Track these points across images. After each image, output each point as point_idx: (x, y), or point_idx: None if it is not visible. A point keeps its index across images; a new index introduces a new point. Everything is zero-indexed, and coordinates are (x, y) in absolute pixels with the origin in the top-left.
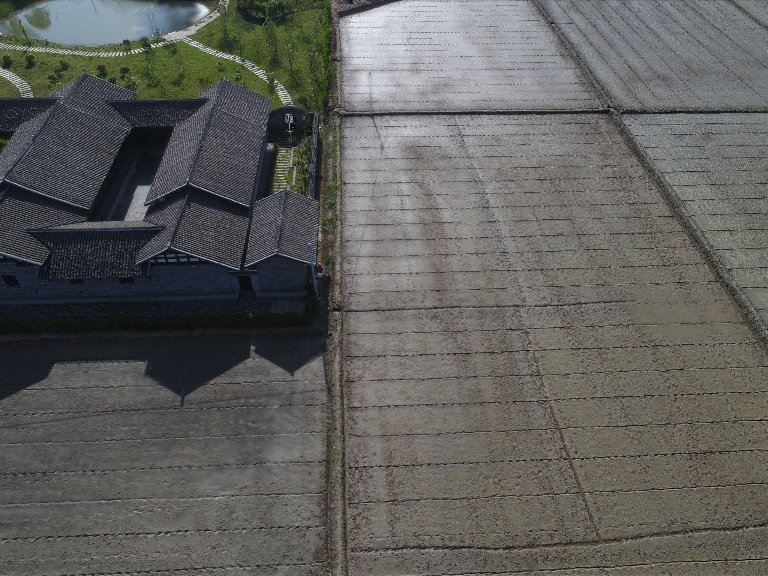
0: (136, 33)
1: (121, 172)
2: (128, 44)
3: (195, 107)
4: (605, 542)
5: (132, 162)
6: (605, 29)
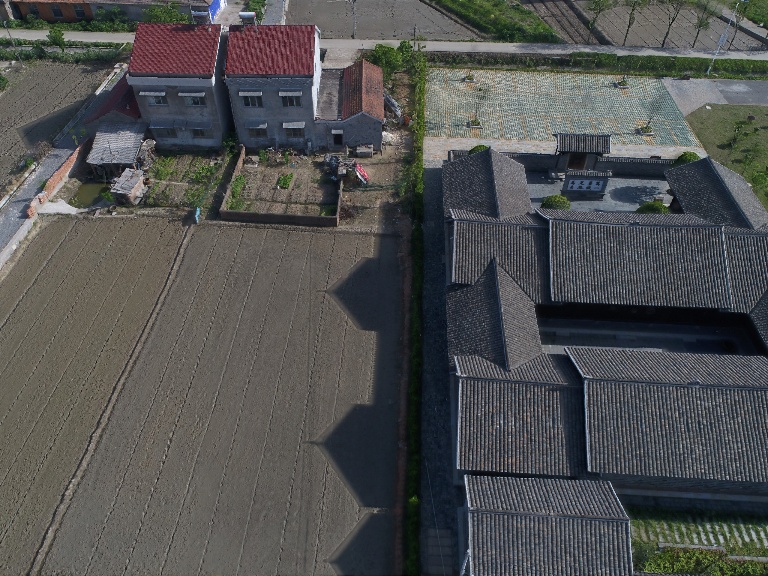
0: None
1: (680, 327)
2: None
3: None
4: None
5: (707, 334)
6: None
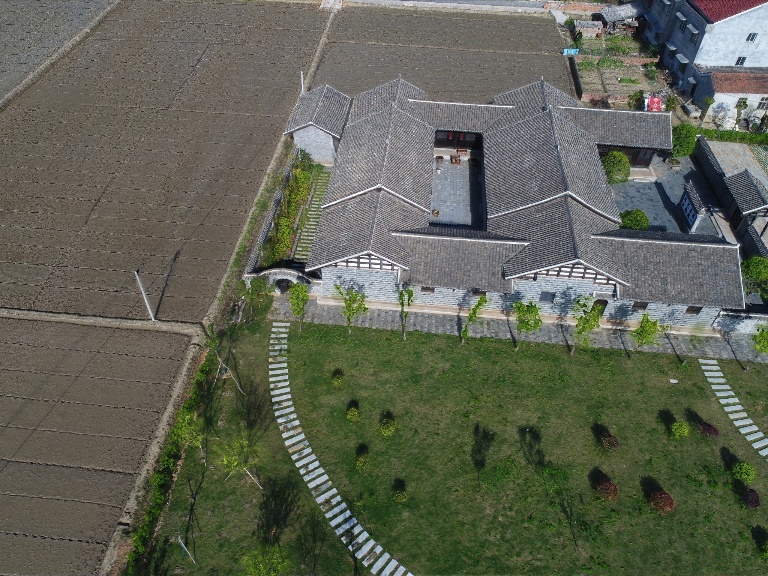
0: None
1: None
2: None
3: (409, 231)
4: None
5: None
6: None
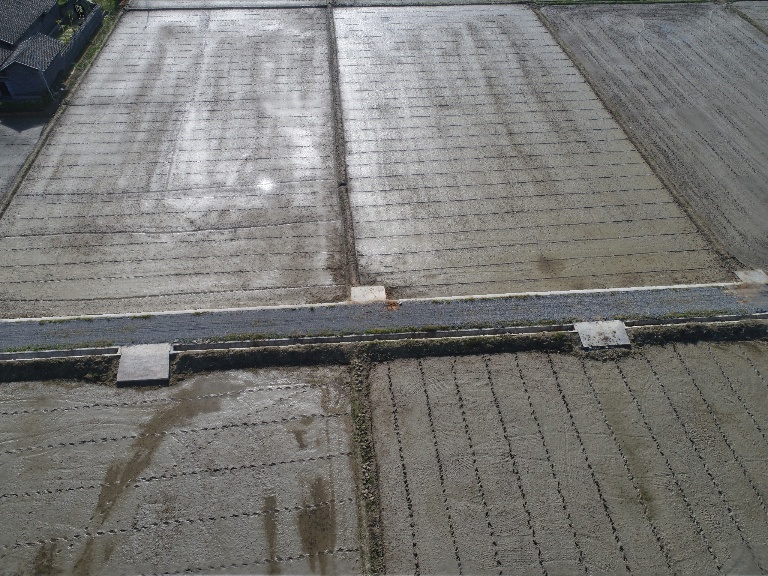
0: None
1: None
2: None
3: None
4: (168, 191)
5: None
6: None
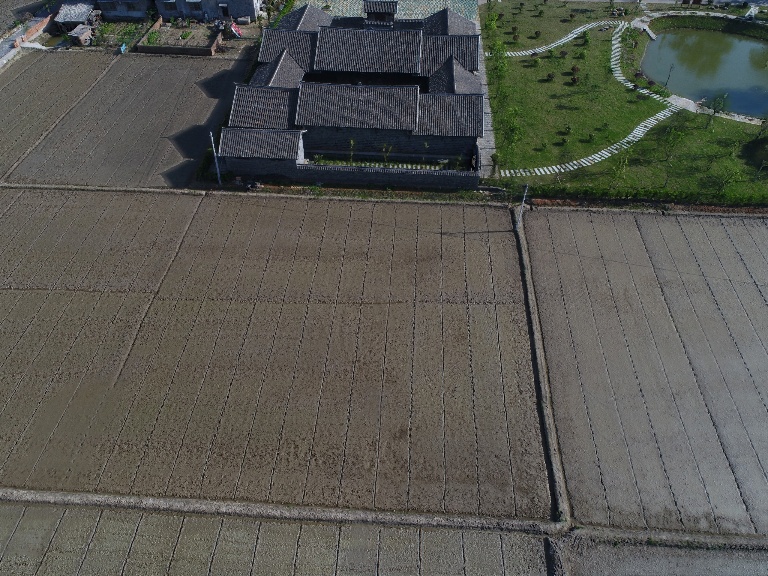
0: (700, 89)
1: None
2: (636, 77)
3: (447, 92)
4: None
5: None
6: None
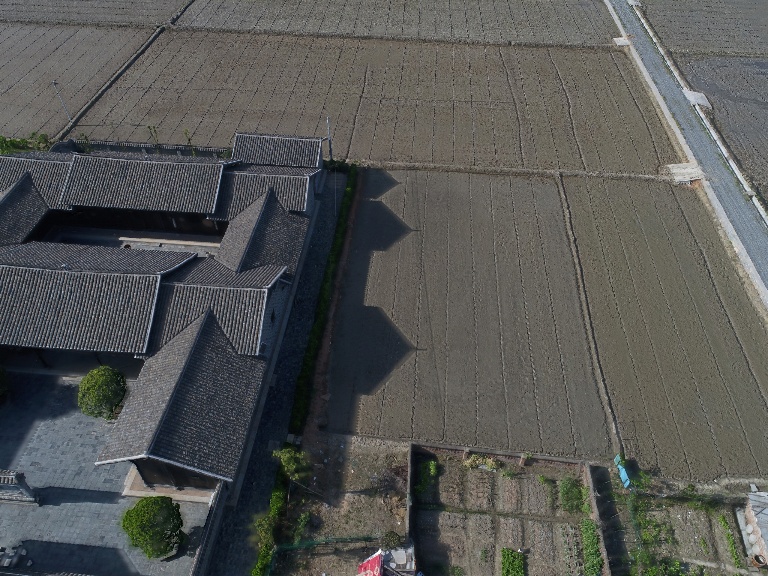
0: None
1: None
2: None
3: (30, 187)
4: None
5: None
6: (27, 2)
